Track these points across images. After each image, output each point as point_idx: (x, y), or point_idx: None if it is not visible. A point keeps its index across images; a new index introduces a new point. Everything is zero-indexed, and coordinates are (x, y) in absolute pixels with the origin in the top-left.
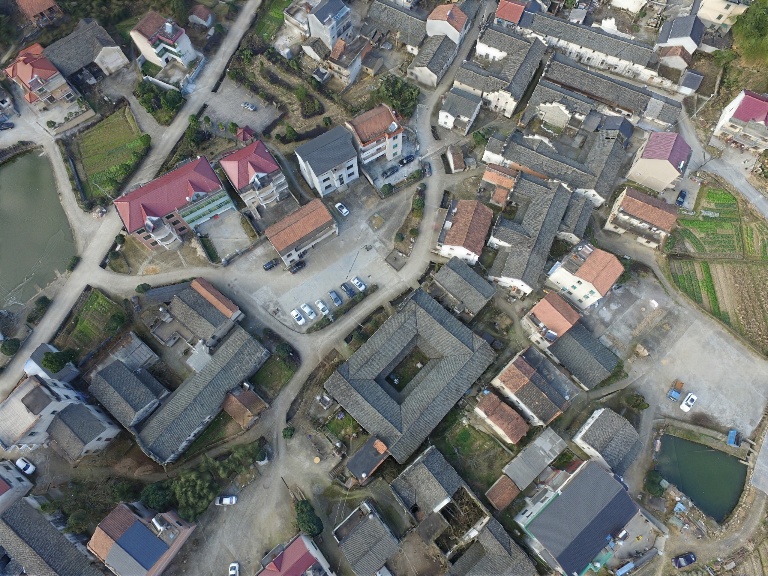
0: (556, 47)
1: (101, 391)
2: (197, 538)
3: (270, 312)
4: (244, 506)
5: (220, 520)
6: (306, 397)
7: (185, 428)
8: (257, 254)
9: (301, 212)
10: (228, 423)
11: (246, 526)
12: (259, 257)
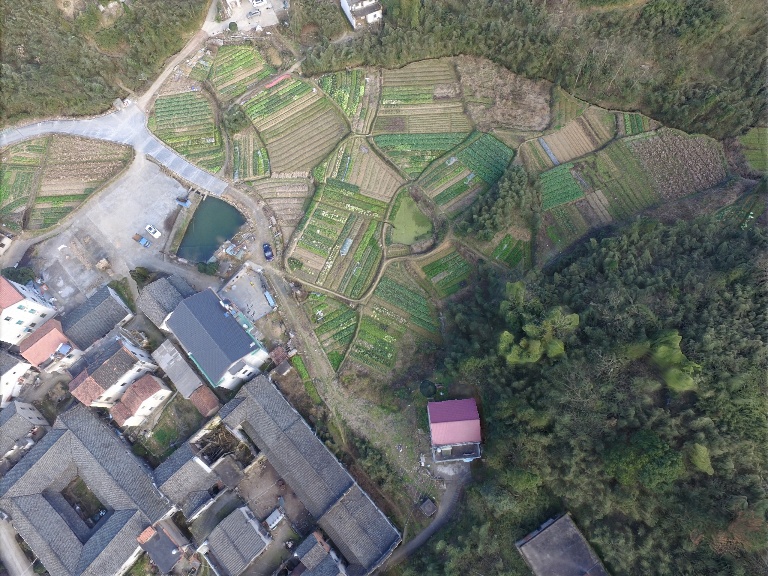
0: None
1: None
2: None
3: None
4: None
5: None
6: None
7: None
8: None
9: None
10: None
11: None
12: None
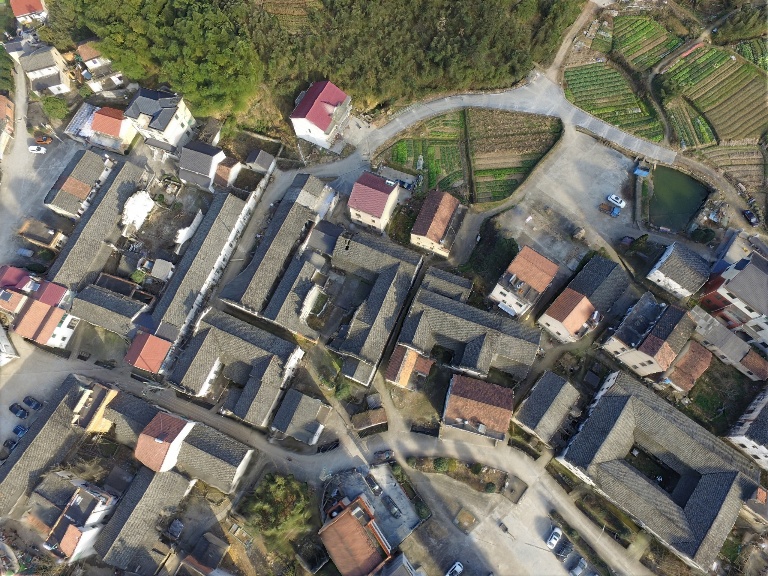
0: (204, 296)
1: None
2: None
3: None
4: None
5: None
6: None
7: None
8: None
9: None
10: None
11: None
12: None
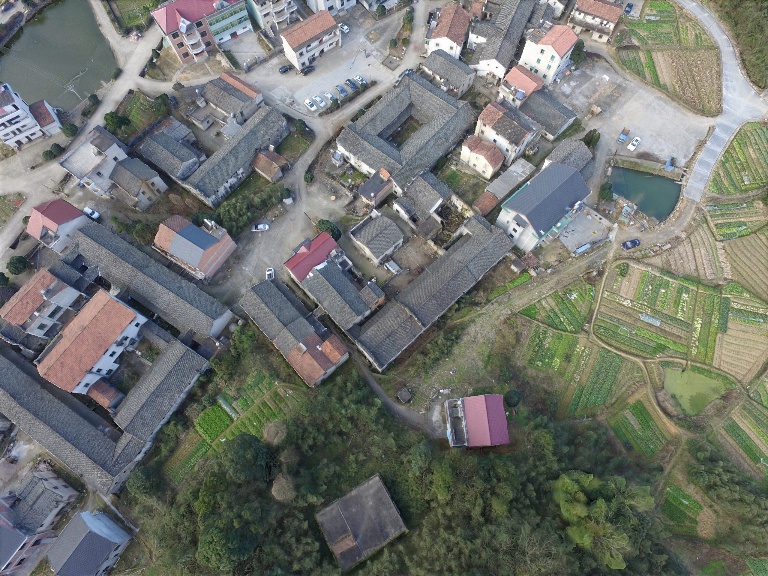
0: None
1: (151, 152)
2: (238, 255)
3: (287, 104)
4: (275, 232)
5: (256, 242)
6: (321, 160)
7: (223, 174)
8: (273, 63)
9: (310, 19)
10: (257, 182)
11: (278, 245)
12: (275, 65)
